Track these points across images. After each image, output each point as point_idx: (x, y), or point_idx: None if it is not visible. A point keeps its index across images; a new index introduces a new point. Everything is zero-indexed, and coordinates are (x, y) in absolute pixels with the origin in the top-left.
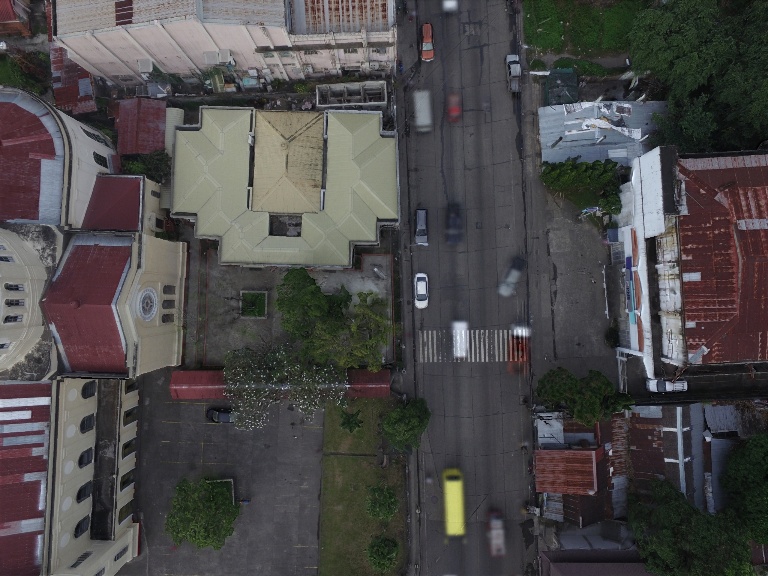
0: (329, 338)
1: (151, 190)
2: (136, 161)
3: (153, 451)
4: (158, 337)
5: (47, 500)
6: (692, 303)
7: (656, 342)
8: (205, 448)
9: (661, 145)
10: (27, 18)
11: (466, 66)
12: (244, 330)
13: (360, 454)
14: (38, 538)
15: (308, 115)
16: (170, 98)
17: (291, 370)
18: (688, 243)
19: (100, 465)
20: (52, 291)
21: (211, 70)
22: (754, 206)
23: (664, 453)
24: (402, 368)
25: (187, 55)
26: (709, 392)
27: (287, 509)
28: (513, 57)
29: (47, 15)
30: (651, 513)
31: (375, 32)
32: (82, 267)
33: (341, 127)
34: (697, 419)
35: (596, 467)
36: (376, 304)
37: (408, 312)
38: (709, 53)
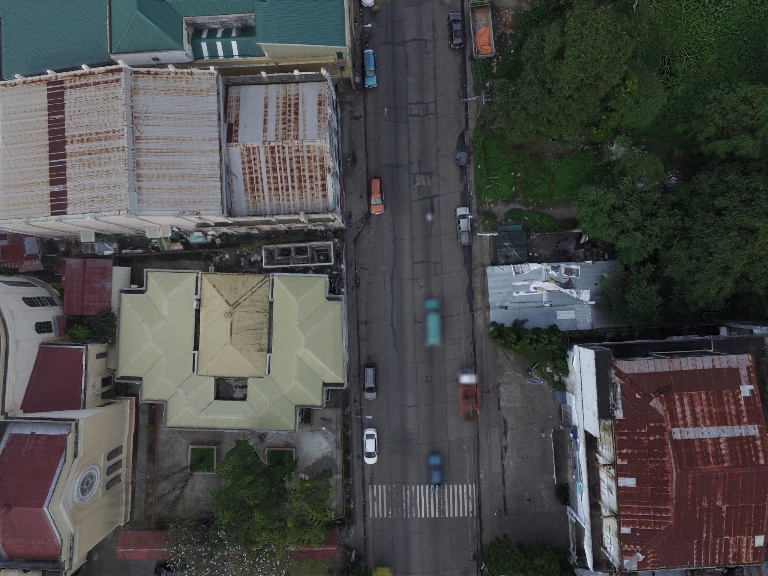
0: (264, 535)
1: (96, 354)
2: (82, 322)
3: None
4: (101, 509)
5: None
6: (627, 509)
7: (596, 531)
8: None
9: (609, 309)
10: None
11: (416, 217)
12: (193, 484)
13: None
14: None
15: (254, 278)
16: (117, 255)
17: (232, 550)
18: (623, 447)
19: None
20: None
21: None
22: (689, 413)
23: None
24: (350, 527)
25: (128, 228)
26: None
27: None
28: (463, 210)
29: None
30: None
31: (314, 214)
32: (17, 461)
33: (286, 292)
34: None
35: None
36: (326, 458)
37: (358, 466)
38: (653, 230)
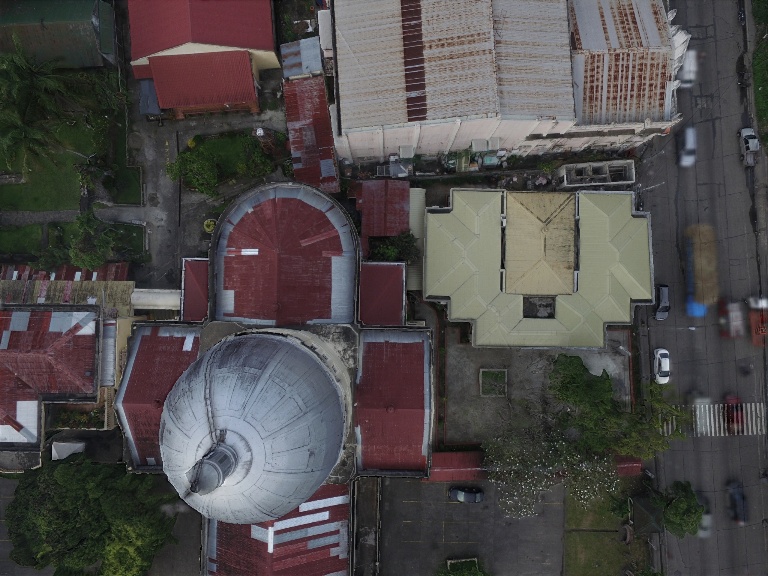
0: (634, 436)
1: None
2: (384, 243)
3: (394, 531)
4: None
5: None
6: None
7: None
8: (446, 527)
9: None
10: (257, 95)
11: (699, 139)
12: (483, 408)
13: (601, 530)
14: None
15: (559, 196)
16: (411, 177)
17: (570, 460)
18: None
19: (361, 552)
20: (360, 394)
21: (461, 152)
22: None
23: None
24: None
25: (453, 142)
26: None
27: None
28: (749, 131)
29: (285, 95)
30: None
31: (657, 122)
32: (381, 367)
33: (595, 208)
34: None
35: None
36: (614, 379)
37: (646, 387)
38: None
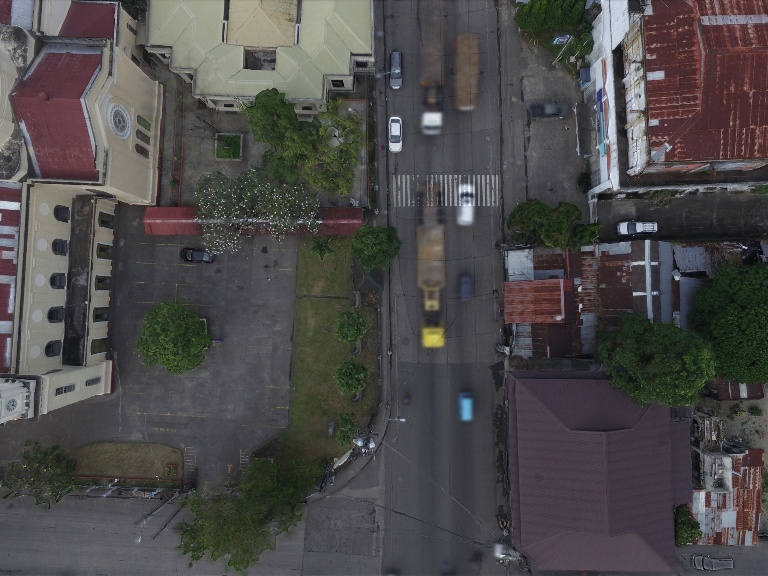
0: (297, 140)
1: (127, 22)
2: None
3: (127, 291)
4: (131, 161)
5: (16, 300)
6: (655, 101)
7: (622, 156)
8: (179, 289)
9: None
10: None
11: None
12: None
13: (333, 297)
14: (7, 341)
15: None
16: None
17: (261, 188)
18: (652, 42)
19: (73, 292)
20: (22, 87)
21: None
22: (718, 4)
23: (632, 287)
24: (375, 208)
25: None
26: (680, 238)
27: (260, 350)
28: None
29: None
30: (617, 334)
31: None
32: (53, 70)
33: None
34: (666, 257)
35: (564, 294)
36: None
37: (382, 157)
38: None
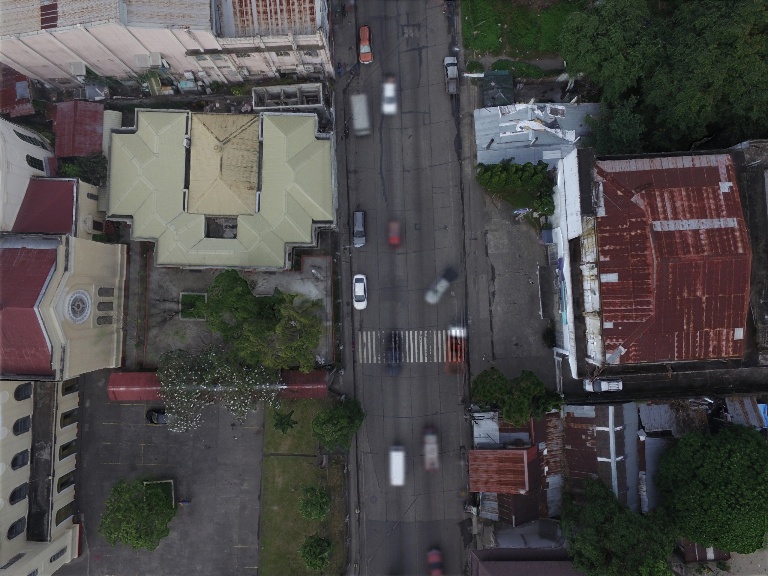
0: (253, 340)
1: (87, 193)
2: (73, 164)
3: (94, 452)
4: (92, 339)
5: None
6: (609, 304)
7: (581, 342)
8: (145, 449)
9: (594, 146)
10: None
11: (405, 68)
12: (184, 332)
13: (300, 454)
14: None
15: (243, 117)
16: (108, 101)
17: (222, 371)
18: (606, 244)
19: (36, 467)
20: None
21: (147, 73)
22: (670, 207)
23: (597, 452)
24: (340, 369)
25: (119, 58)
26: (646, 391)
27: (227, 510)
28: (451, 59)
29: None
30: (580, 512)
31: (302, 35)
32: (8, 270)
33: (276, 129)
34: (631, 418)
35: (527, 466)
36: (316, 305)
37: (347, 313)
38: (636, 55)
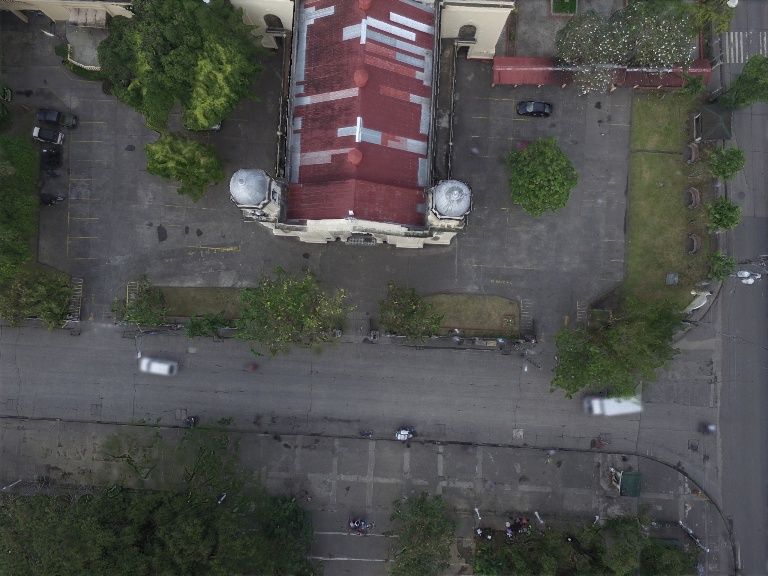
0: None
1: None
2: None
3: (463, 145)
4: None
5: None
6: None
7: None
8: (514, 143)
9: None
10: None
11: None
12: (553, 29)
13: (666, 152)
14: (419, 160)
15: None
16: None
17: (648, 22)
18: None
19: None
20: None
21: None
22: None
23: None
24: (716, 61)
25: None
26: None
27: (594, 204)
28: None
29: None
30: None
31: None
32: None
33: None
34: None
35: None
36: None
37: None
38: None
